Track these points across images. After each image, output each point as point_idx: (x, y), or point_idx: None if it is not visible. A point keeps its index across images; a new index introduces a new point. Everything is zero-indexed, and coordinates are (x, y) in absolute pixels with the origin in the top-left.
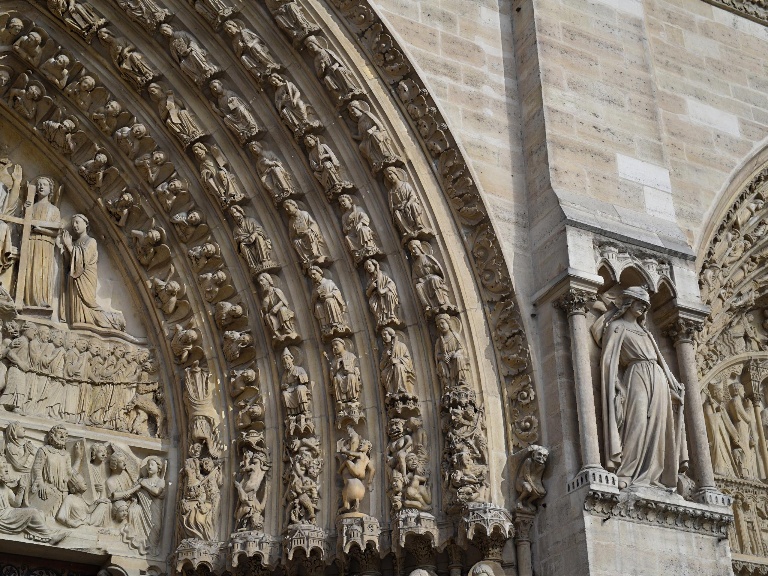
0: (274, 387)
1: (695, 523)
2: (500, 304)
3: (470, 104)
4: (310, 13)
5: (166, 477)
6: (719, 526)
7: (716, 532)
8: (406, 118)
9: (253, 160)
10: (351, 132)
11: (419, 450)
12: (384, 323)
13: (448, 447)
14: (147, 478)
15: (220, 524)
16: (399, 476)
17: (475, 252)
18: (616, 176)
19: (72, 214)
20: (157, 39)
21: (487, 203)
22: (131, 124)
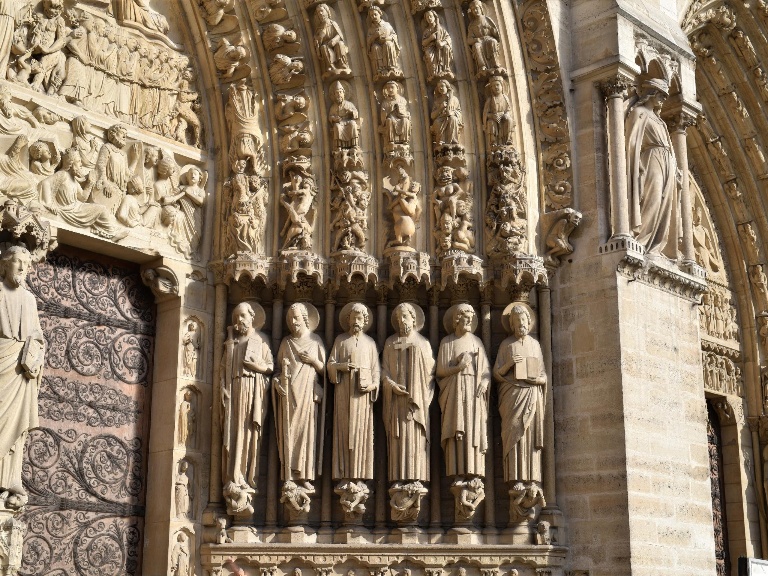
0: (321, 117)
1: (681, 289)
2: (544, 75)
3: None
4: None
5: (205, 187)
6: (695, 293)
7: (692, 298)
8: None
9: None
10: None
11: (467, 198)
12: (441, 75)
13: (496, 200)
14: (188, 186)
15: (266, 240)
16: (450, 219)
17: (526, 21)
18: None
19: None
20: None
21: None
22: None
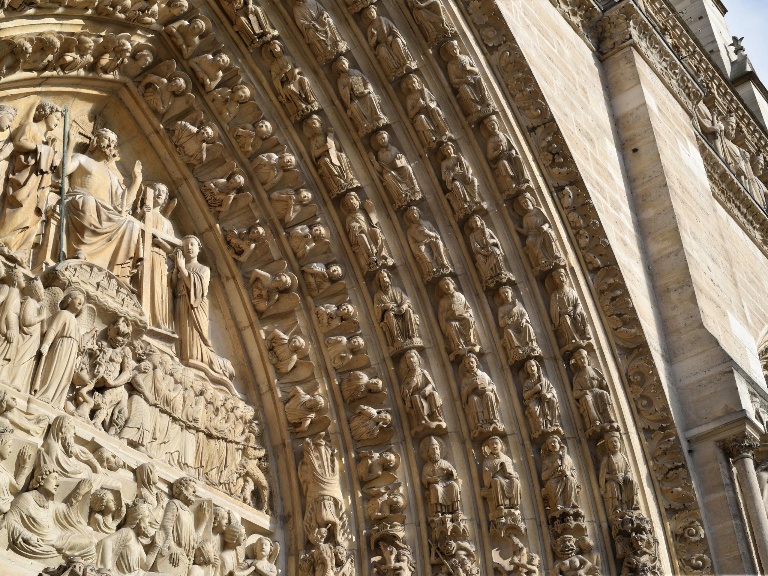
0: (412, 478)
1: None
2: (659, 433)
3: (617, 227)
4: (489, 92)
5: (275, 562)
6: None
7: None
8: (565, 224)
9: (403, 226)
10: (515, 223)
11: (597, 573)
12: (550, 430)
13: (632, 574)
14: None
15: None
16: None
17: (631, 375)
18: (731, 331)
19: (176, 234)
20: (324, 70)
21: (644, 328)
22: (280, 152)
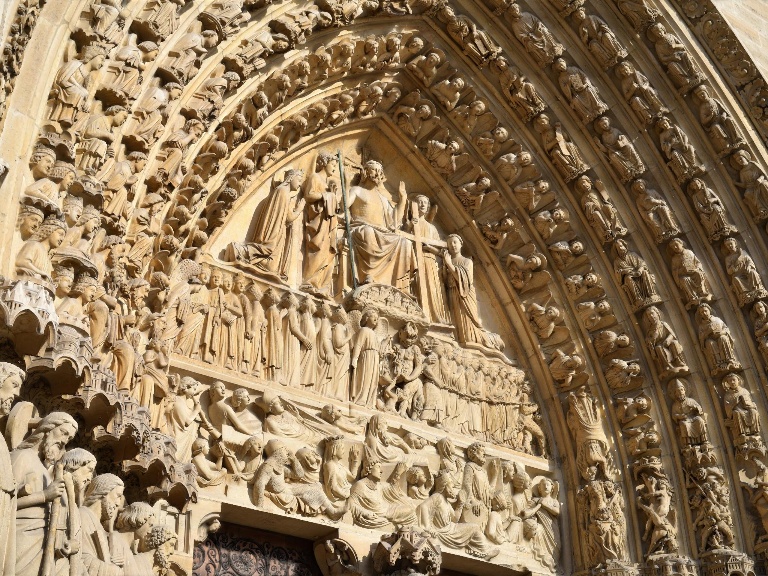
0: (664, 416)
1: None
2: None
3: None
4: (697, 62)
5: (557, 497)
6: None
7: None
8: None
9: (632, 196)
10: (733, 179)
11: None
12: None
13: None
14: None
15: (629, 546)
16: None
17: None
18: None
19: (441, 233)
20: (545, 71)
21: None
22: (517, 151)
